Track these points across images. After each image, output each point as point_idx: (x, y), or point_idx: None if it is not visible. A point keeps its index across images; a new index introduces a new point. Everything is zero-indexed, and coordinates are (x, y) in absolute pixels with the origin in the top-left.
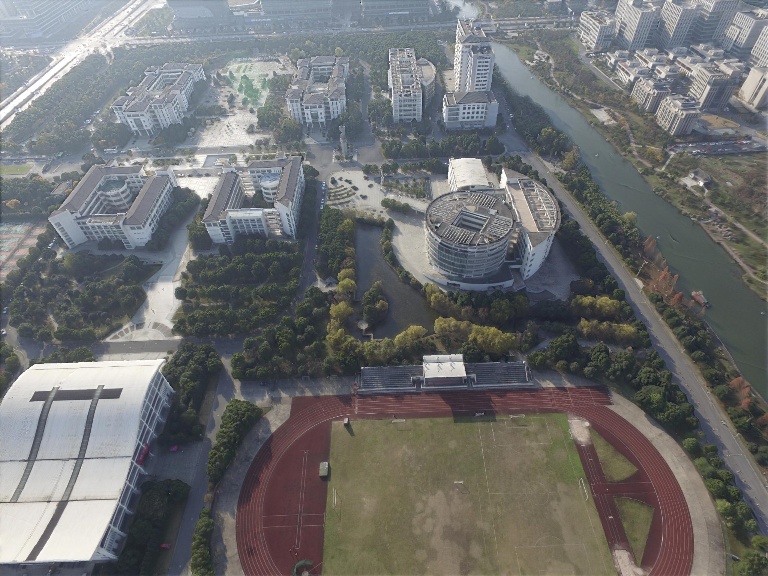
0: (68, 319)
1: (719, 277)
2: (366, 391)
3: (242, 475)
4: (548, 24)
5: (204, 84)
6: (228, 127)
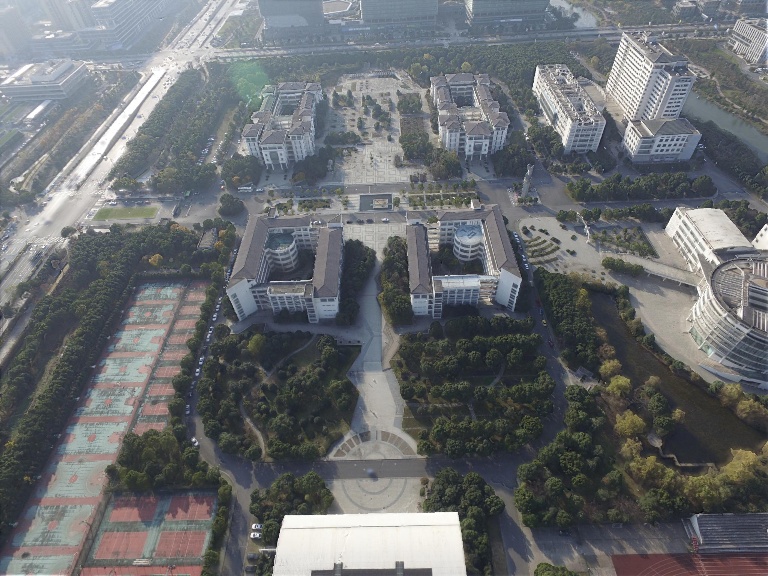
0: (279, 429)
1: None
2: (709, 549)
3: None
4: (685, 32)
5: (325, 106)
6: (372, 159)
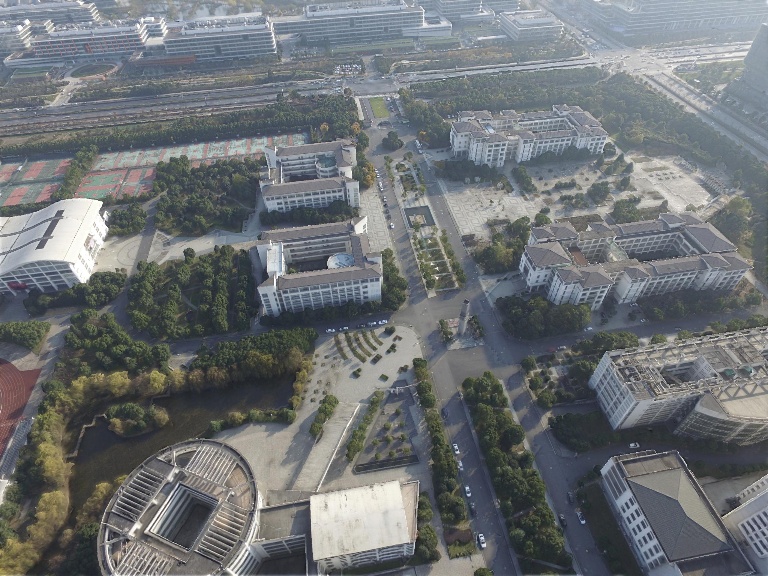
0: None
1: None
2: None
3: None
4: None
5: (582, 154)
6: (491, 203)
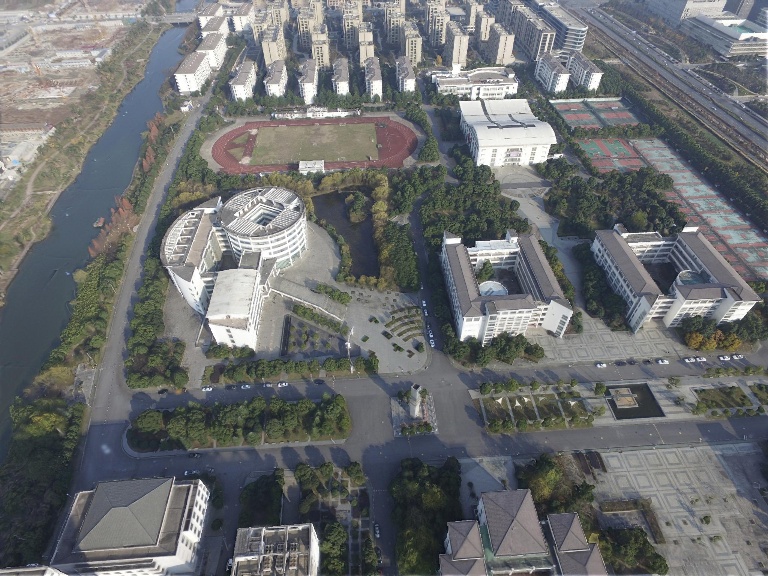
0: None
1: (57, 246)
2: None
3: (419, 144)
4: None
5: None
6: (705, 519)
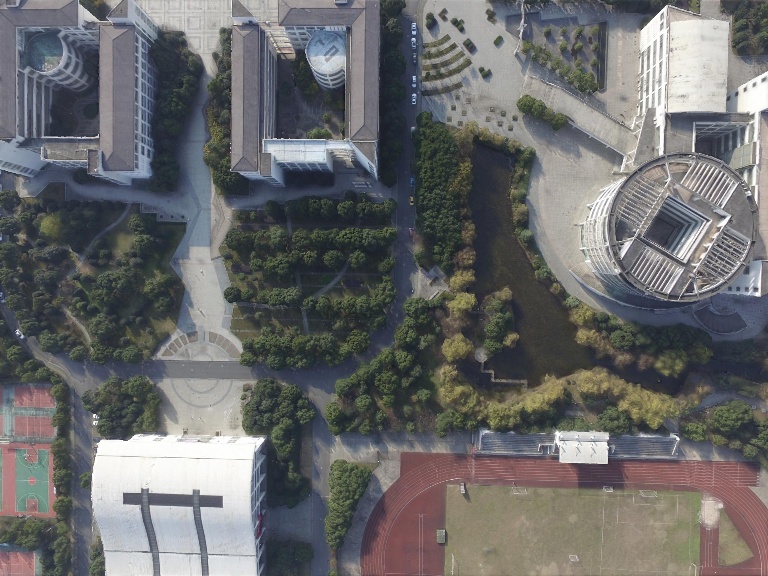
0: (98, 335)
1: None
2: (484, 452)
3: (360, 535)
4: None
5: None
6: None
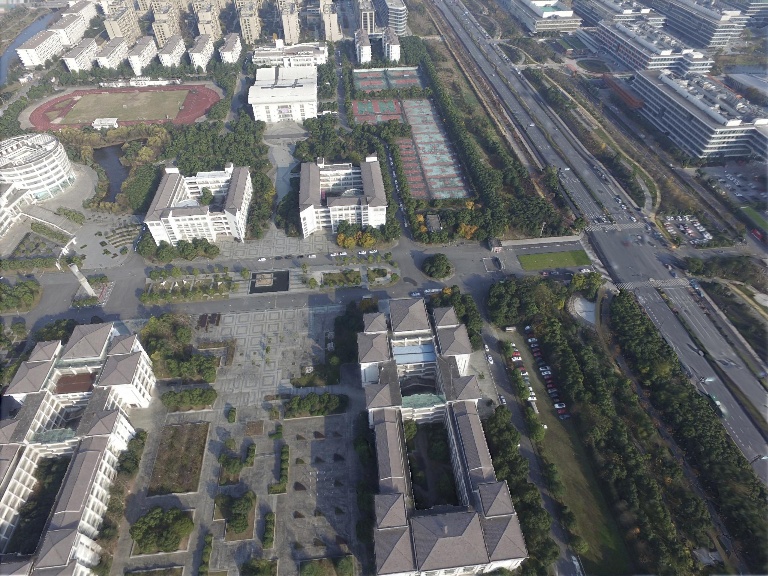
0: None
1: None
2: None
3: None
4: None
5: None
6: (268, 349)
